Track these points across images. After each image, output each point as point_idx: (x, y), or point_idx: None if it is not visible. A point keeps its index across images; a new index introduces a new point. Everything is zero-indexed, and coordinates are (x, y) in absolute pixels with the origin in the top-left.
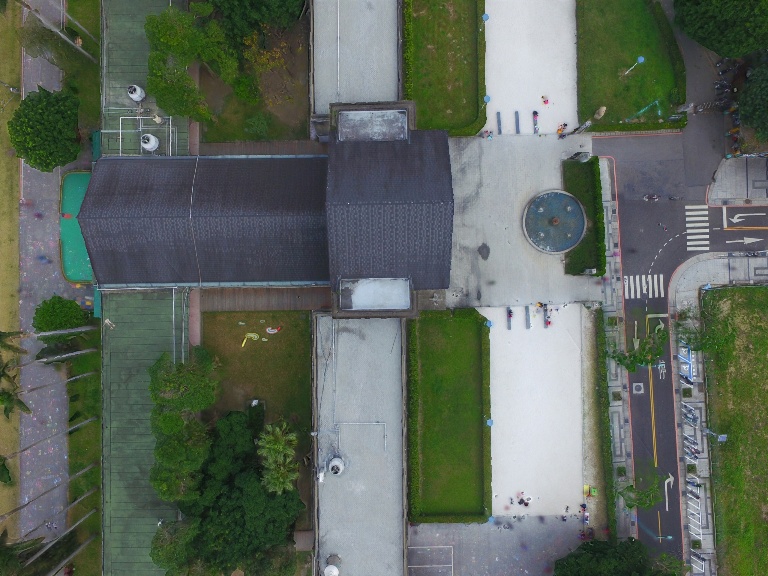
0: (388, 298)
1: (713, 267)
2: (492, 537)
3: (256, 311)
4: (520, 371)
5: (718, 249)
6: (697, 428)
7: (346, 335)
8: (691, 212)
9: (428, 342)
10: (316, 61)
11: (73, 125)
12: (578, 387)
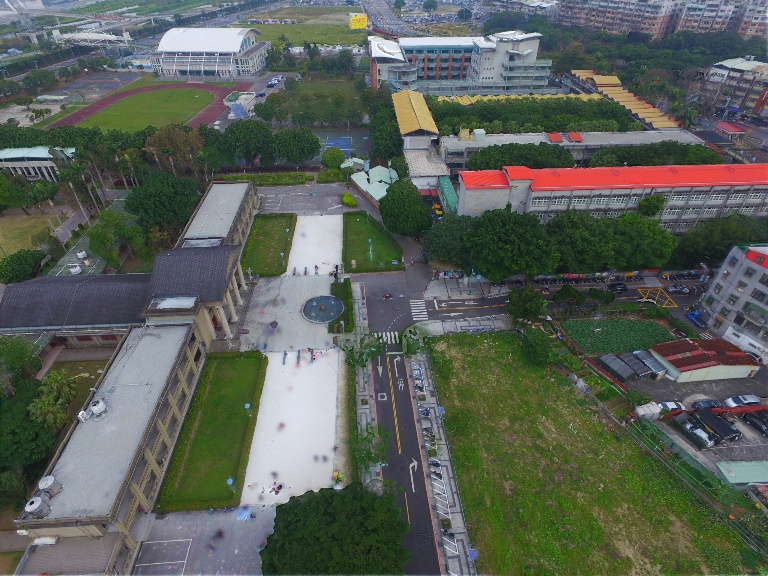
0: (181, 306)
1: (432, 327)
2: (236, 527)
3: (96, 360)
4: (288, 390)
5: (434, 319)
6: (433, 422)
7: (148, 337)
8: (414, 303)
9: (220, 374)
10: (186, 235)
11: (36, 262)
12: (334, 398)
